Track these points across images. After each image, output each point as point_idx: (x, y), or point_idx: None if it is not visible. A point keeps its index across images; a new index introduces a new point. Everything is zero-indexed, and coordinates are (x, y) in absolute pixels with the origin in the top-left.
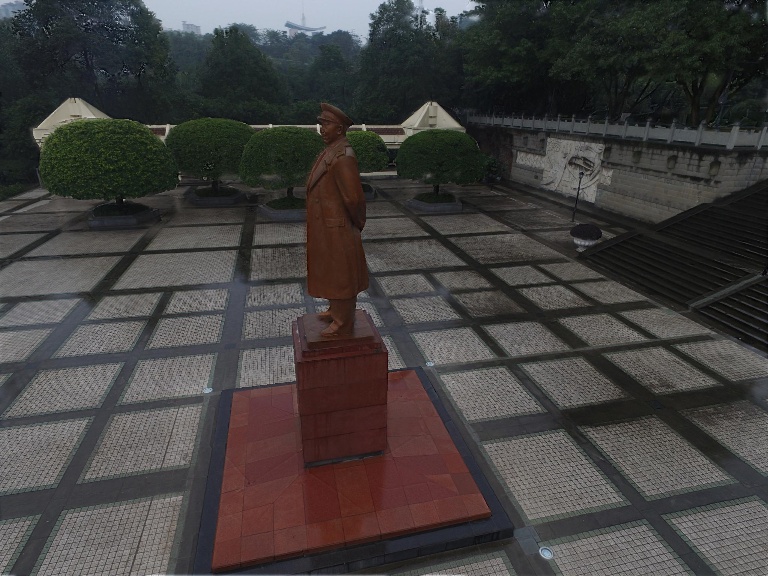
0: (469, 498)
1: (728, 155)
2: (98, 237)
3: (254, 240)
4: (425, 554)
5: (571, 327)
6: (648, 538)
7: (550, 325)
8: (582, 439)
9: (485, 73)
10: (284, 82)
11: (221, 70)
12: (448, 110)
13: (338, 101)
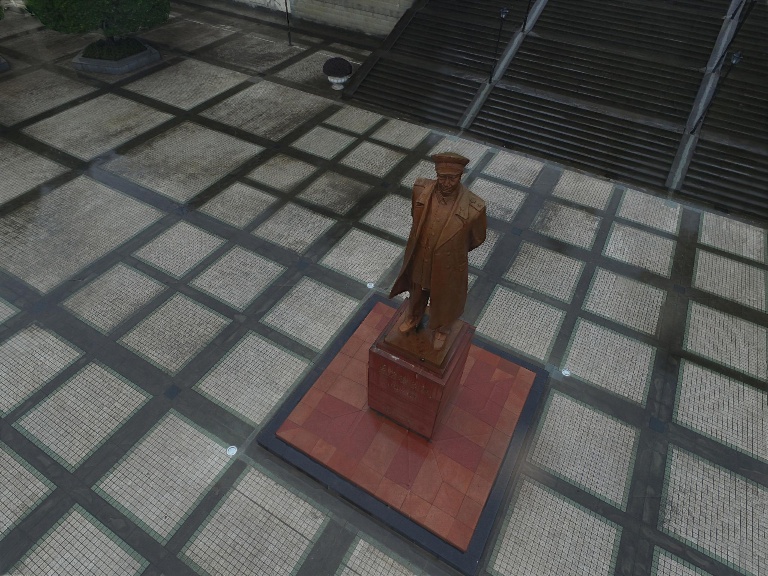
0: (521, 375)
1: None
2: None
3: None
4: None
5: None
6: (588, 327)
7: (402, 193)
8: (512, 285)
9: None
10: None
11: None
12: None
13: None
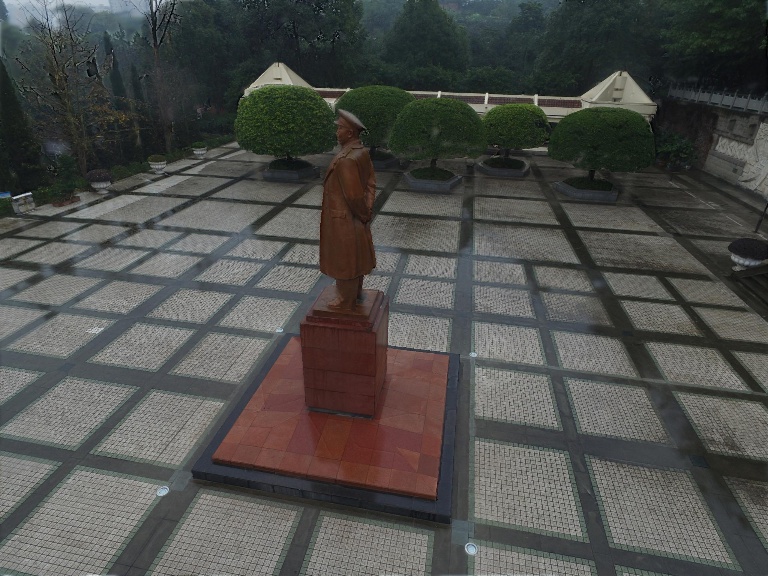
0: (423, 478)
1: None
2: (265, 187)
3: (383, 206)
4: (366, 508)
5: (656, 354)
6: None
7: (631, 346)
8: (581, 467)
9: (686, 41)
10: (465, 47)
11: (405, 35)
12: (641, 82)
13: (515, 68)
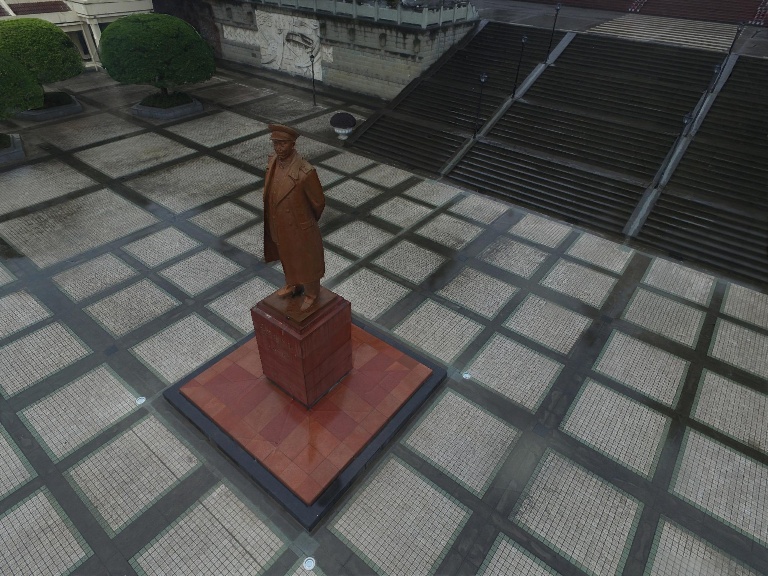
0: (417, 369)
1: (424, 34)
2: None
3: None
4: (413, 414)
5: (383, 217)
6: (502, 341)
7: (368, 220)
8: (442, 300)
9: None
10: None
11: None
12: None
13: None
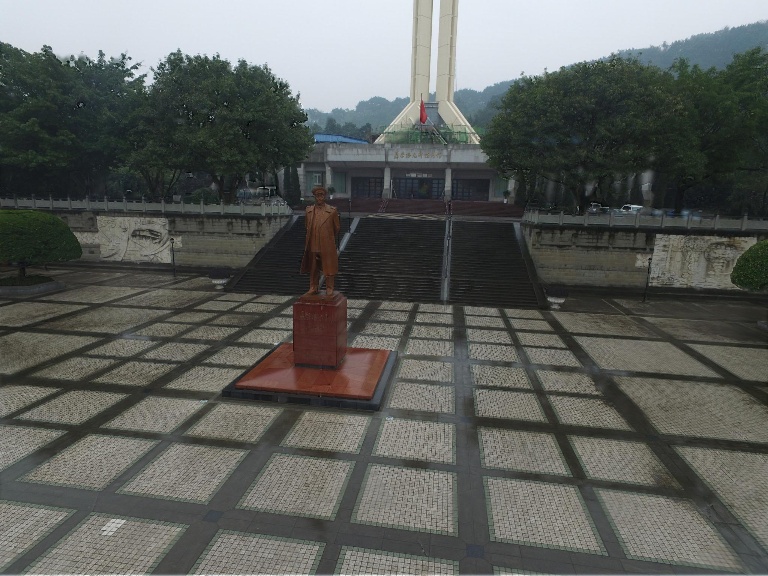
0: None
1: (264, 219)
2: None
3: None
4: None
5: None
6: None
7: (283, 316)
8: (366, 334)
9: (25, 156)
10: None
11: None
12: None
13: None
